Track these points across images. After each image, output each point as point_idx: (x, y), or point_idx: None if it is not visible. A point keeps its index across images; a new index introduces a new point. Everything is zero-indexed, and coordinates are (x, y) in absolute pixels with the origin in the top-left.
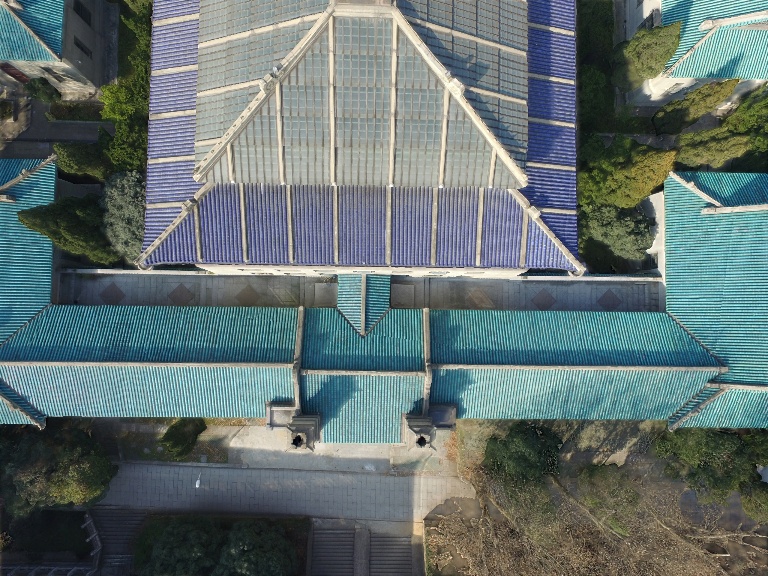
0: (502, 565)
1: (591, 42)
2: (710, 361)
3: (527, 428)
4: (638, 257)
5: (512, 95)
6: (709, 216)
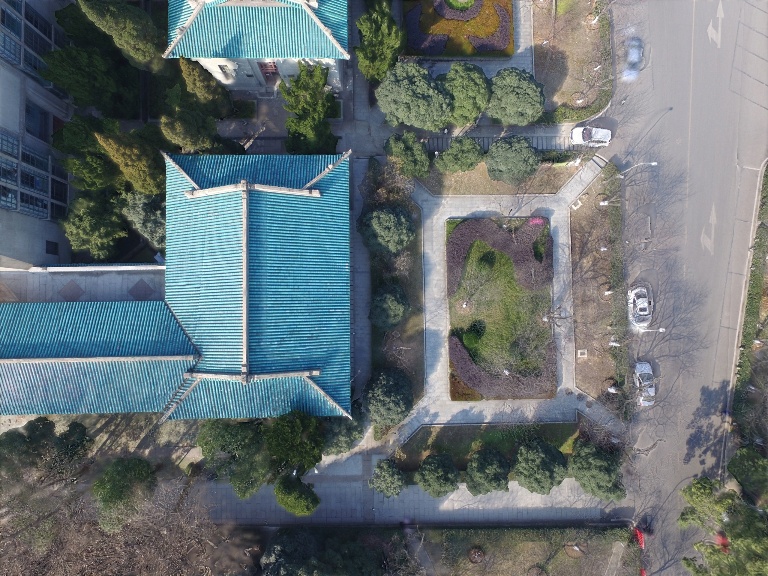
0: (30, 567)
1: (167, 25)
2: (187, 350)
3: (34, 424)
4: (160, 245)
5: None
6: (194, 200)
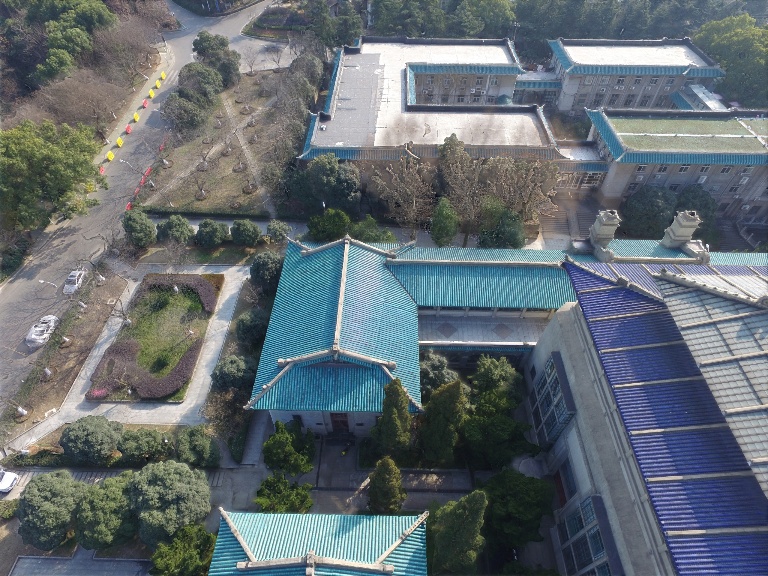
0: None
1: None
2: (395, 268)
3: None
4: None
5: (699, 328)
6: None
